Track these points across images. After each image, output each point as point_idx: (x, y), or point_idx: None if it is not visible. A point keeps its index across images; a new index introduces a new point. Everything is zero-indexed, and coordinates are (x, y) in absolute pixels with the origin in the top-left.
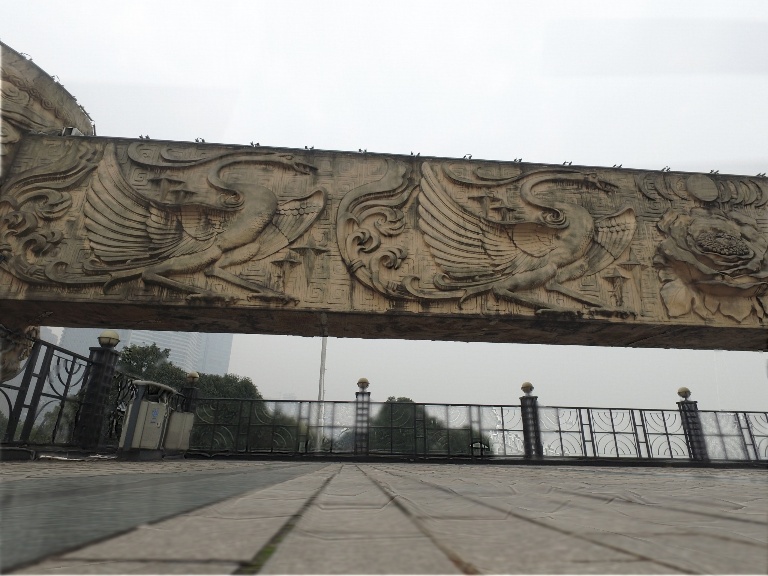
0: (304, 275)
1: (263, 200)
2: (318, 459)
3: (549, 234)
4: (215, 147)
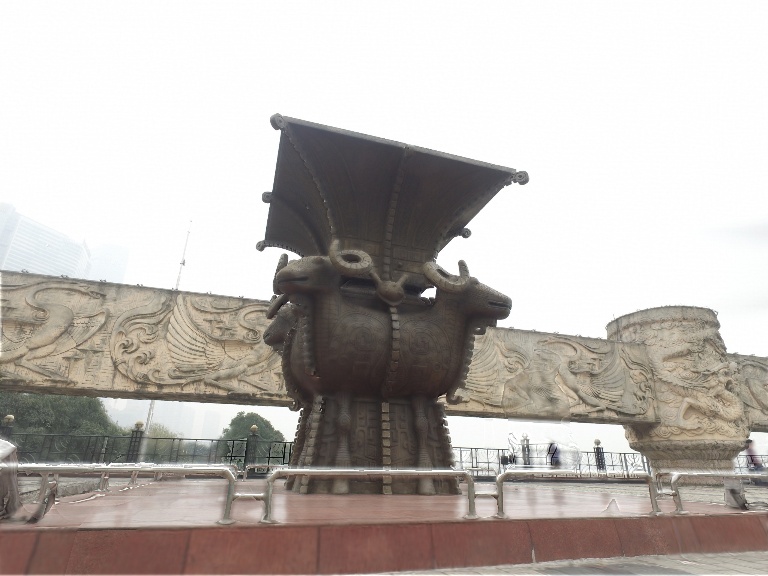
0: (83, 366)
1: (62, 317)
2: (96, 476)
3: (247, 346)
4: (35, 276)
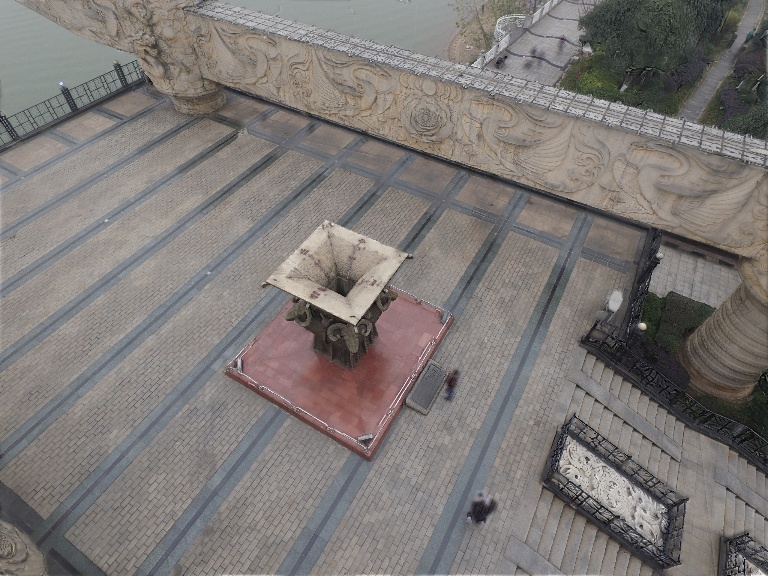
0: None
1: None
2: None
3: None
4: None
